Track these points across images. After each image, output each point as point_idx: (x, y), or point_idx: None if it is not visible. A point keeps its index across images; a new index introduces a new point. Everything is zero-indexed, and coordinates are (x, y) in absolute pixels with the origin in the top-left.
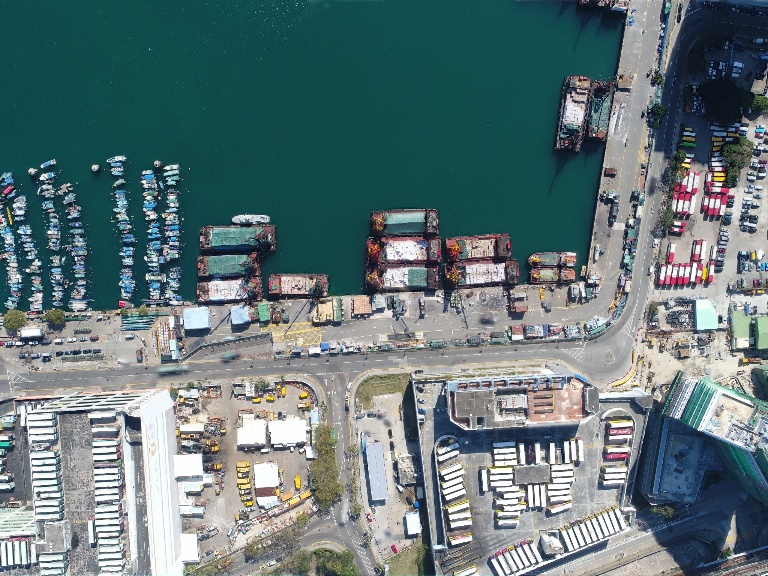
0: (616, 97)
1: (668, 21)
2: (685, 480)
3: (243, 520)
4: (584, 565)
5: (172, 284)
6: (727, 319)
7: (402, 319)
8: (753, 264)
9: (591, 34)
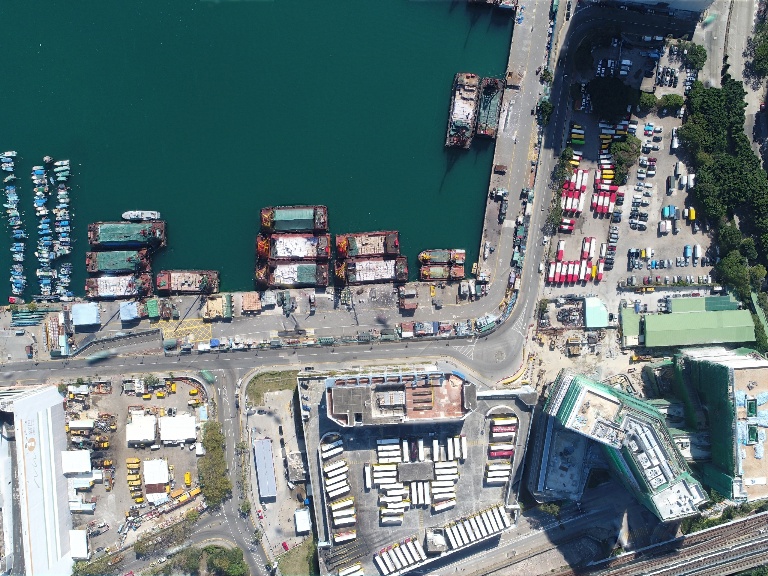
0: (506, 94)
1: (556, 18)
2: (570, 478)
3: (133, 517)
4: (476, 563)
5: (63, 280)
6: (618, 317)
7: (293, 316)
8: (643, 262)
9: (481, 31)
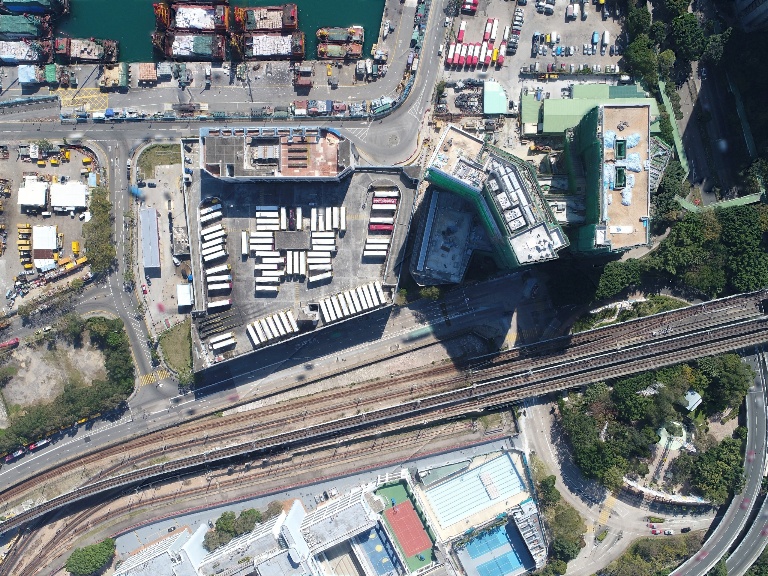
0: None
1: None
2: (452, 259)
3: (21, 282)
4: (358, 354)
5: None
6: (518, 105)
7: (188, 89)
8: (548, 48)
9: None
